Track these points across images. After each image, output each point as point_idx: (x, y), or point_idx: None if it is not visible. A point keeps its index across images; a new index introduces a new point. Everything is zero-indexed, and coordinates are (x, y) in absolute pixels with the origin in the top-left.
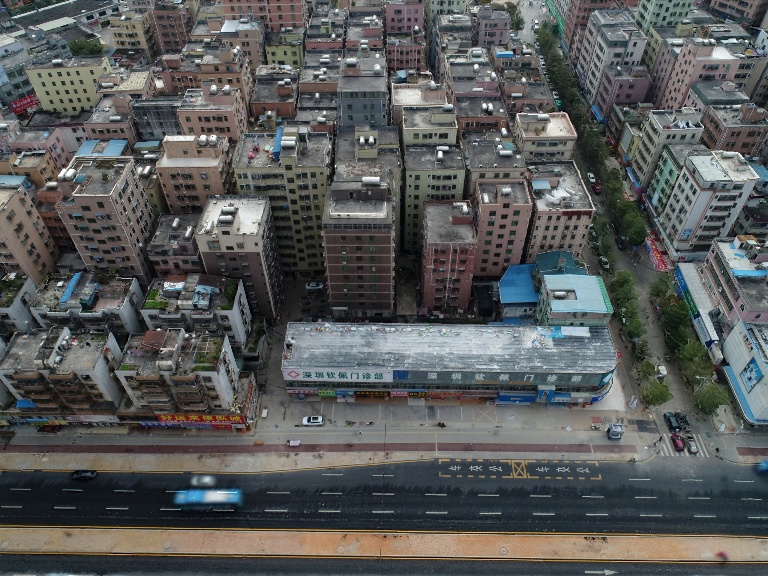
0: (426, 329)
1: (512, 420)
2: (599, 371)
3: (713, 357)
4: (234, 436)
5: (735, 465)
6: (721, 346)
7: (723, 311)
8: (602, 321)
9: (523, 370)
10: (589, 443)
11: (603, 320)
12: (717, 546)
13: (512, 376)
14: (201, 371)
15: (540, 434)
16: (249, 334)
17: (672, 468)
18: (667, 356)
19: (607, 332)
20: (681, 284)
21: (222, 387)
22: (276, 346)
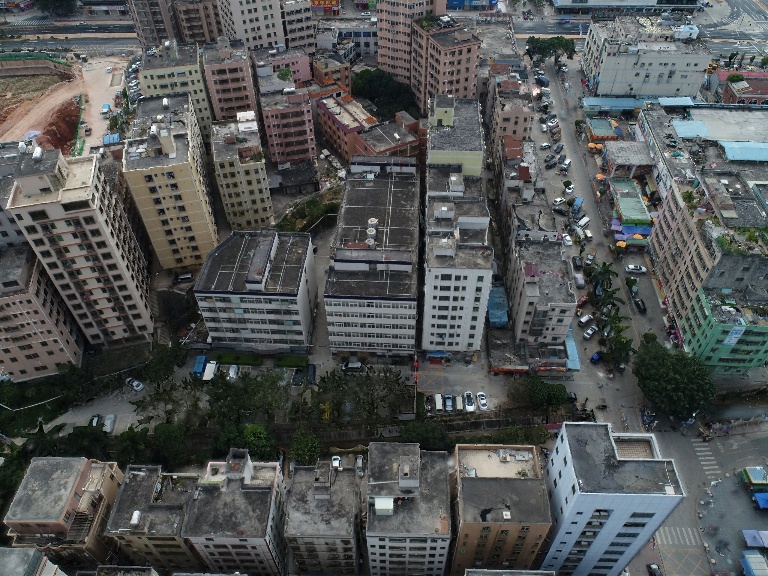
0: None
1: (454, 14)
2: None
3: None
4: None
5: (549, 22)
6: None
7: None
8: None
9: None
10: None
11: None
12: None
13: None
14: None
15: None
16: None
17: (521, 23)
18: None
19: None
20: None
21: None
22: None
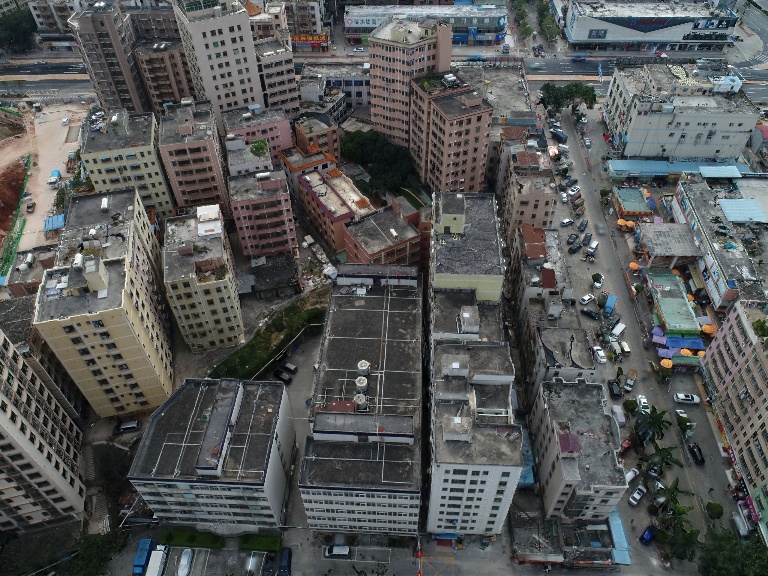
0: (414, 7)
1: (457, 50)
2: (497, 16)
3: (560, 25)
4: (321, 54)
5: (562, 60)
6: (565, 22)
7: (566, 4)
8: (502, 2)
9: (461, 16)
10: (493, 55)
11: (502, 1)
12: (545, 77)
13: (455, 20)
14: (310, 2)
15: (470, 53)
16: (325, 15)
17: (532, 61)
18: (540, 32)
19: (504, 7)
20: (552, 5)
21: (318, 15)
22: (337, 31)
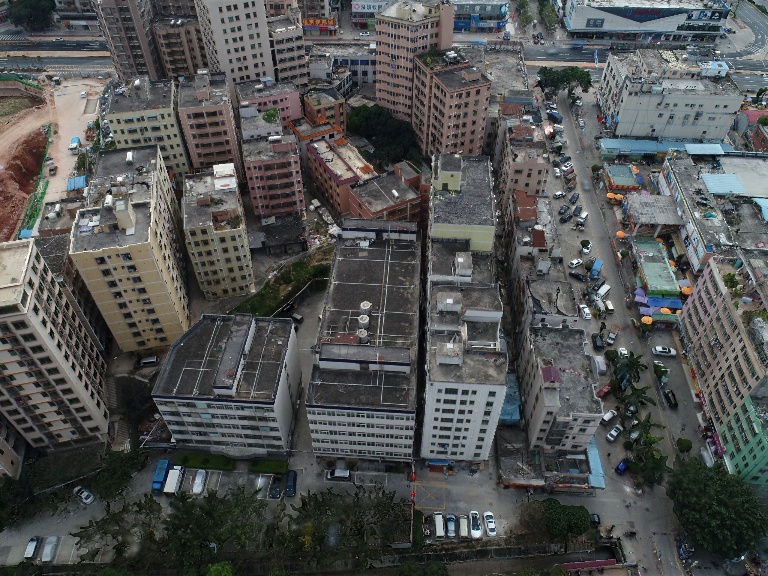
0: None
1: (460, 36)
2: (499, 4)
3: (559, 14)
4: (328, 37)
5: (561, 47)
6: (564, 11)
7: None
8: None
9: (464, 3)
10: None
11: None
12: None
13: (459, 7)
14: None
15: (472, 39)
16: (333, 0)
17: None
18: (540, 21)
19: None
20: None
21: None
22: (344, 16)
